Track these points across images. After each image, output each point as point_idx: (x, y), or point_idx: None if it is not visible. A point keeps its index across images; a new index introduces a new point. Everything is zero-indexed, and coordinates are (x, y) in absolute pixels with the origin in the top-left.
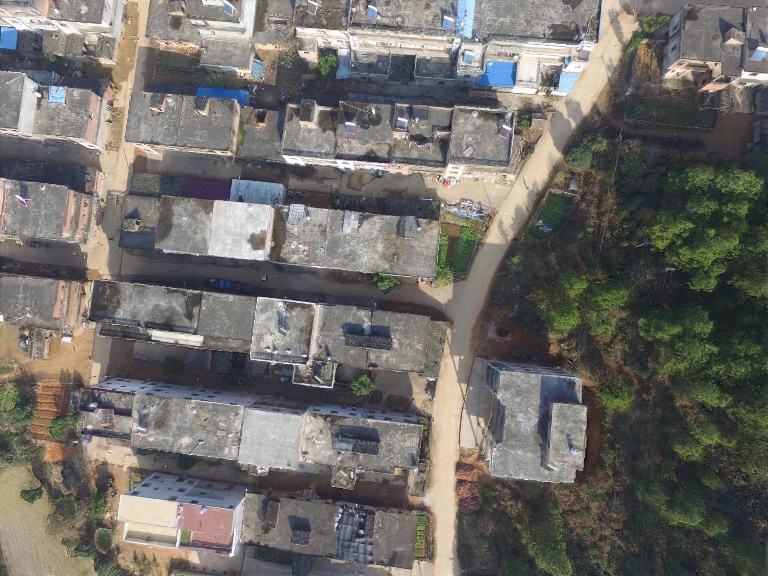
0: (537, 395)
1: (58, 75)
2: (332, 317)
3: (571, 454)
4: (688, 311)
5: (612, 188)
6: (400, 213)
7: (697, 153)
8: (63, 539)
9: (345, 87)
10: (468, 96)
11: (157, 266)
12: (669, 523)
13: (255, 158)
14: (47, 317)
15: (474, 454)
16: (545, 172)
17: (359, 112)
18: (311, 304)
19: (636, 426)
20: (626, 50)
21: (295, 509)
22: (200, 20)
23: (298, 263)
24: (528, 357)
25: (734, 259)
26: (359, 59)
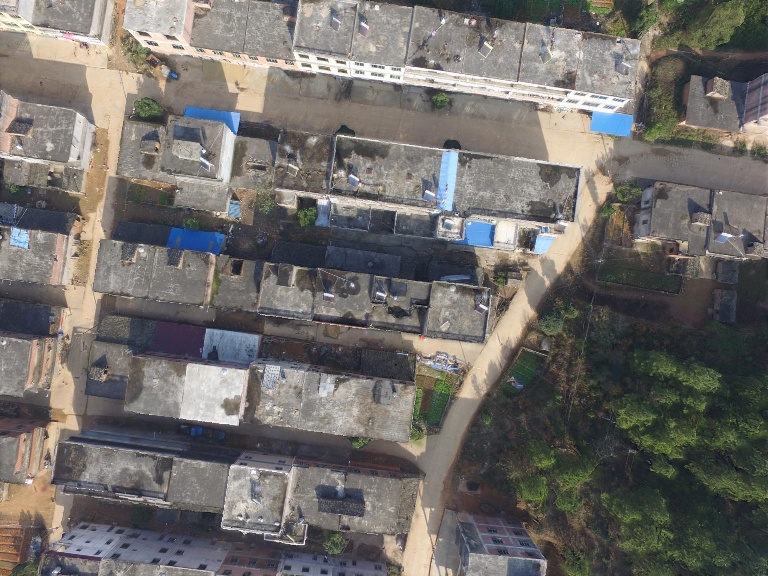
0: None
1: (20, 207)
2: (305, 479)
3: None
4: (647, 495)
5: None
6: (376, 369)
7: (662, 326)
8: None
9: (324, 232)
10: (446, 249)
11: None
12: None
13: (230, 308)
14: (7, 477)
15: None
16: (519, 329)
17: (338, 280)
18: (285, 473)
19: None
20: (600, 213)
21: None
22: (175, 173)
23: (272, 425)
24: (496, 511)
25: (691, 447)
26: (339, 212)
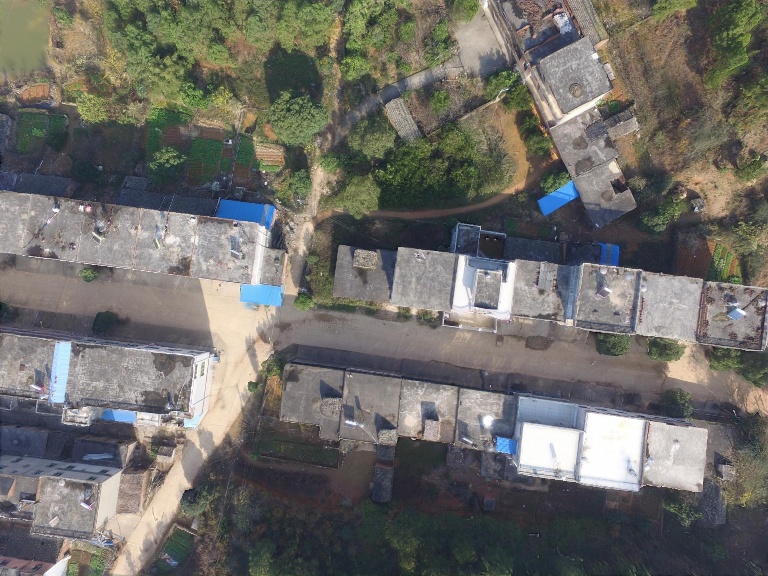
0: None
1: None
2: None
3: None
4: None
5: (225, 535)
6: (20, 550)
7: (298, 513)
8: None
9: None
10: (104, 420)
11: None
12: None
13: None
14: None
15: None
16: (174, 503)
17: None
18: None
19: None
20: None
21: None
22: None
23: None
24: None
25: None
26: None
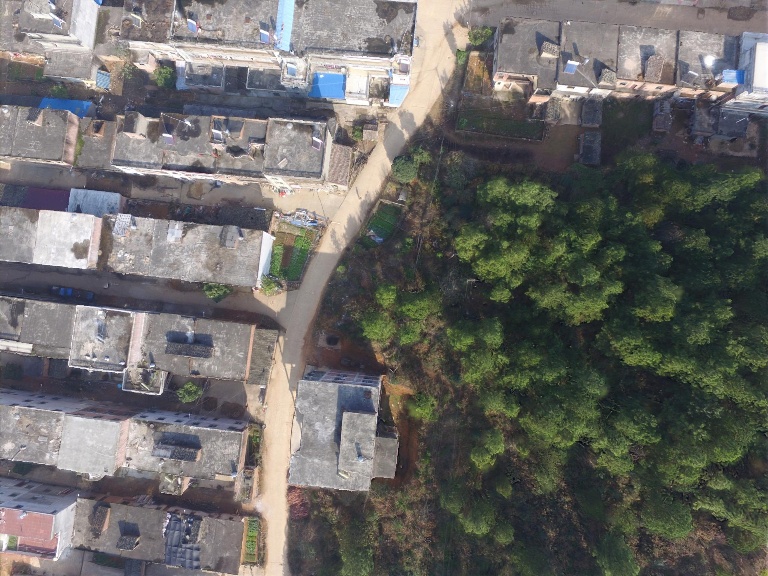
0: (334, 404)
1: None
2: (157, 325)
3: (359, 463)
4: (484, 322)
5: (436, 199)
6: (231, 223)
7: (514, 165)
8: None
9: (188, 98)
10: (305, 107)
11: (4, 273)
12: None
13: (93, 168)
14: None
15: None
16: (378, 182)
17: (179, 124)
18: (130, 312)
19: (449, 435)
20: None
21: (125, 514)
22: (31, 33)
23: (124, 272)
24: (356, 365)
25: (529, 270)
26: (195, 71)
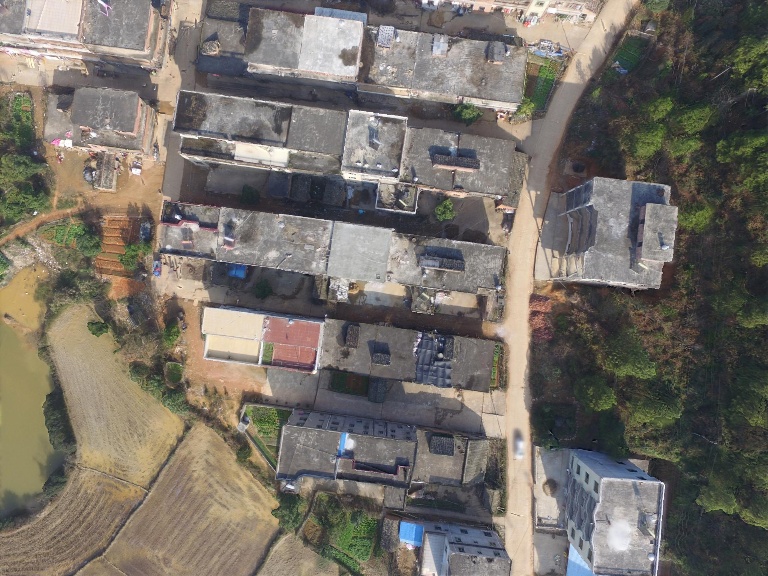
0: (628, 201)
1: None
2: (419, 139)
3: (662, 251)
4: None
5: (689, 28)
6: None
7: None
8: (132, 370)
9: None
10: None
11: None
12: (740, 335)
13: None
14: (128, 130)
15: (548, 286)
16: (622, 15)
17: None
18: (403, 119)
19: (709, 249)
20: None
21: (374, 334)
22: None
23: (386, 85)
24: None
25: None
26: None
